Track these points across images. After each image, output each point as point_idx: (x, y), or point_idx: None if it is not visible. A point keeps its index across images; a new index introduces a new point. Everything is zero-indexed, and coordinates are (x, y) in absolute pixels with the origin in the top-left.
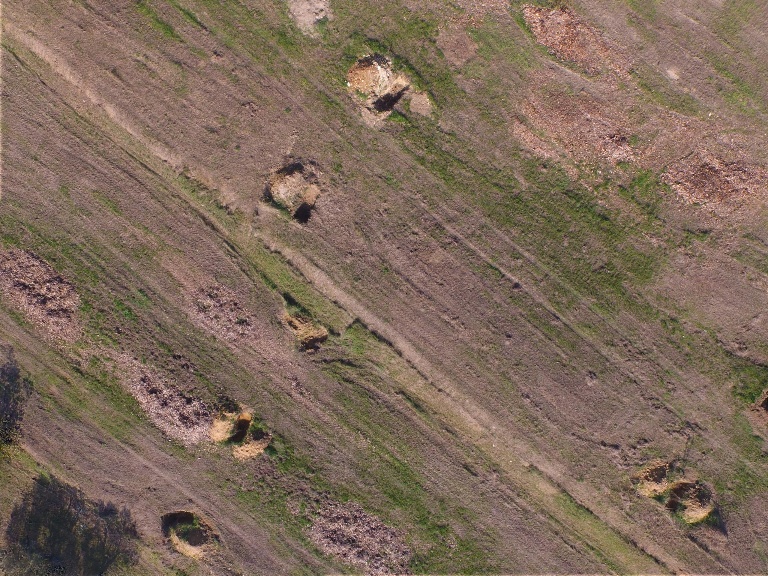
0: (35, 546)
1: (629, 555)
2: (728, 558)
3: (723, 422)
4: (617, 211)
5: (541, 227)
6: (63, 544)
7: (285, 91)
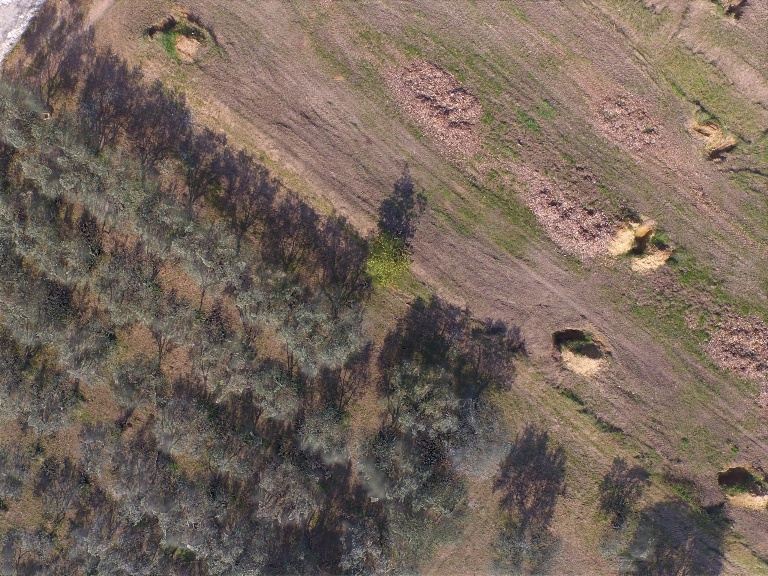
0: None
1: None
2: None
3: None
4: None
5: None
6: None
7: None
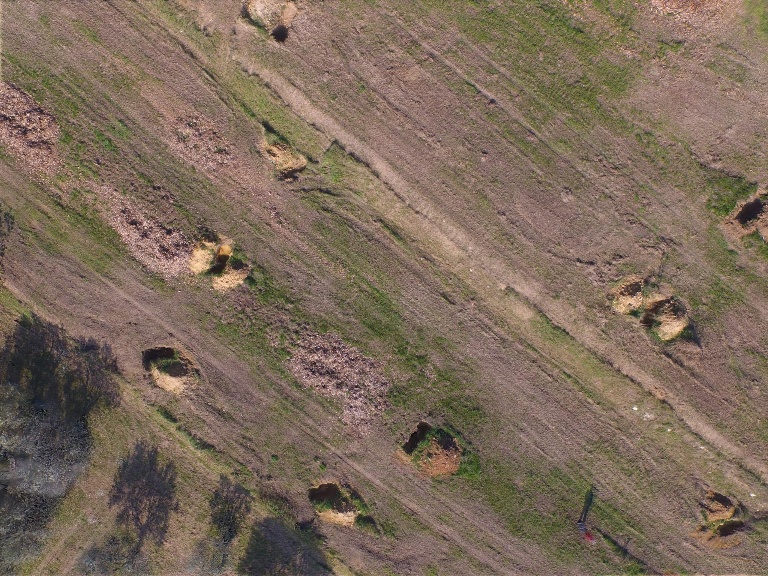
0: (18, 389)
1: (605, 379)
2: (703, 373)
3: (698, 236)
4: (592, 24)
5: (516, 42)
6: (45, 387)
7: None
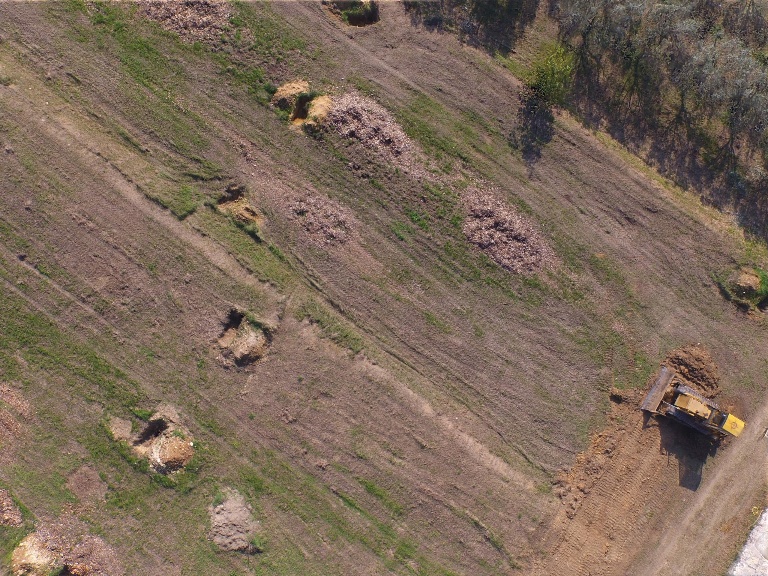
0: None
1: None
2: None
3: None
4: None
5: None
6: None
7: (255, 435)
